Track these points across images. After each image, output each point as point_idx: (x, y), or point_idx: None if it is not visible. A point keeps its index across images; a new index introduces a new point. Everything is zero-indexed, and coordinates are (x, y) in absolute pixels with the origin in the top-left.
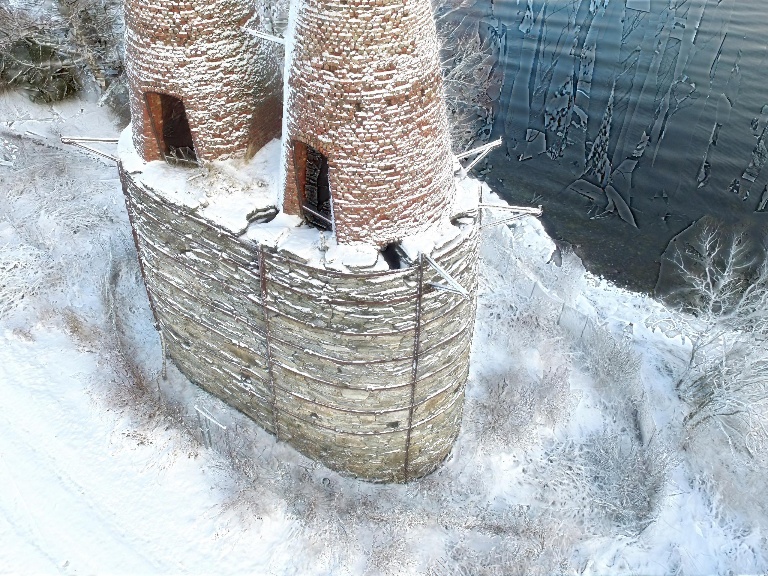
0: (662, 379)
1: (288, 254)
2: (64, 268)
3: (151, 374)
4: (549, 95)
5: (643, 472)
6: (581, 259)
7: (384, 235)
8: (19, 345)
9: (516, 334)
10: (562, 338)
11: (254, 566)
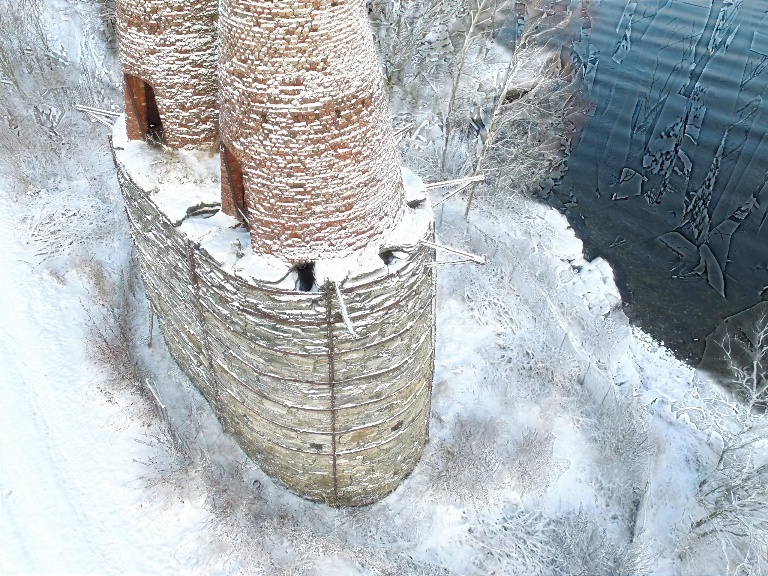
0: (687, 473)
1: (207, 253)
2: (117, 224)
3: (141, 339)
4: (654, 134)
5: (607, 570)
6: (645, 318)
7: (296, 253)
8: (50, 286)
9: (515, 384)
10: (580, 399)
11: (162, 546)
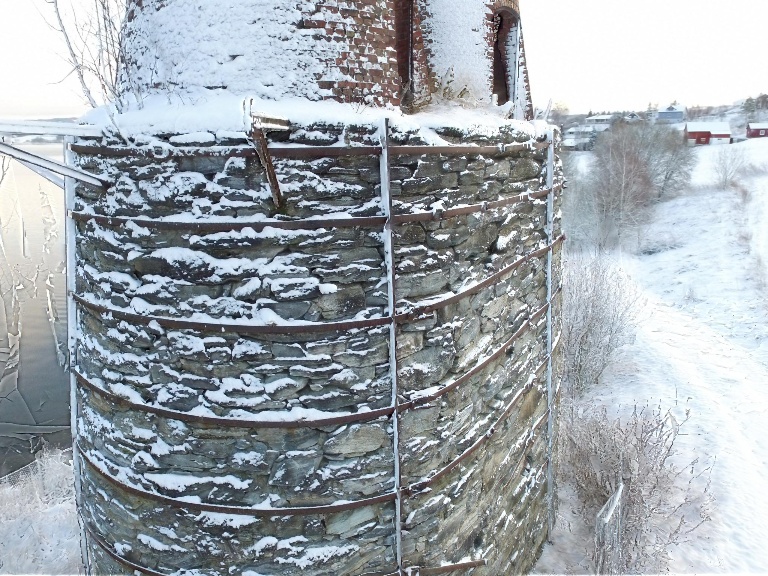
0: None
1: None
2: None
3: None
4: None
5: None
6: None
7: None
8: None
9: None
10: None
11: None
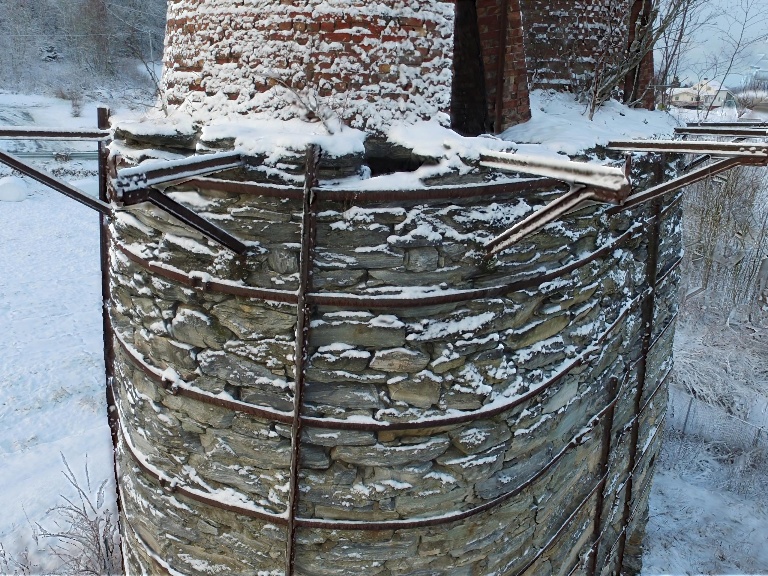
0: None
1: None
2: None
3: None
4: None
5: None
6: None
7: None
8: None
9: None
10: None
11: None
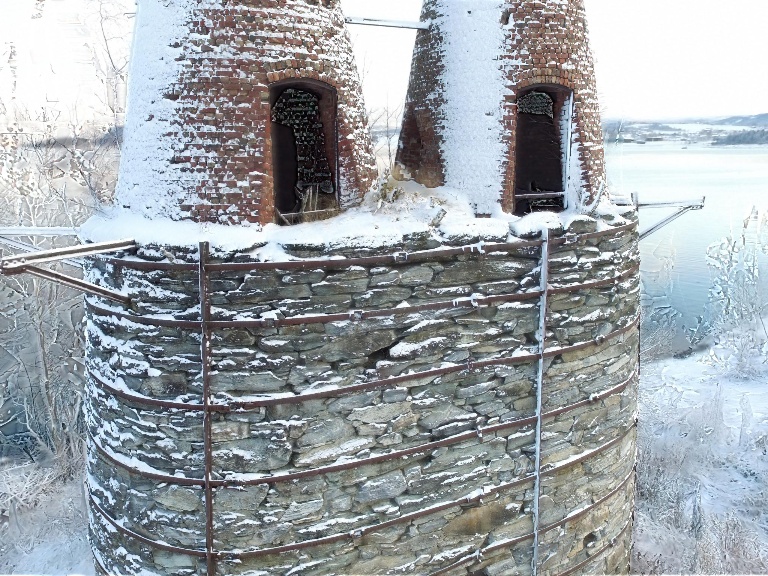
0: None
1: (577, 227)
2: None
3: None
4: None
5: None
6: None
7: None
8: None
9: None
10: None
11: None
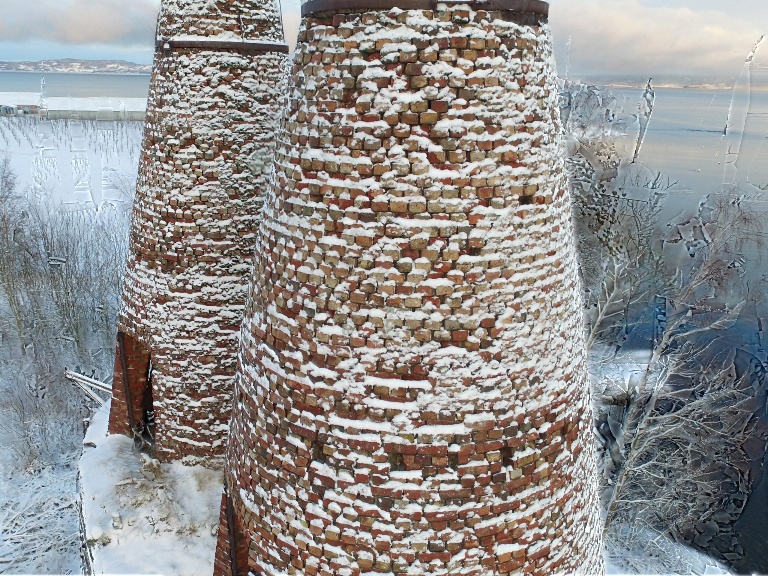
0: None
1: None
2: None
3: None
4: None
5: None
6: None
7: None
8: None
9: None
10: None
11: None
